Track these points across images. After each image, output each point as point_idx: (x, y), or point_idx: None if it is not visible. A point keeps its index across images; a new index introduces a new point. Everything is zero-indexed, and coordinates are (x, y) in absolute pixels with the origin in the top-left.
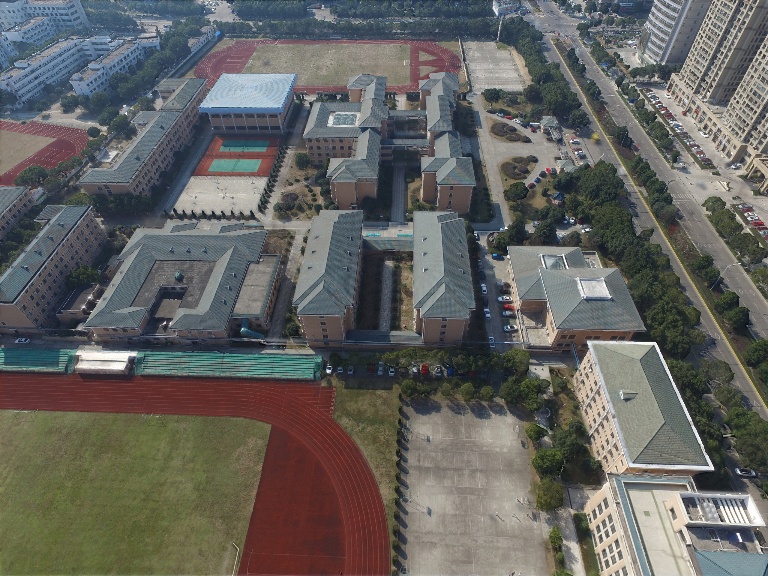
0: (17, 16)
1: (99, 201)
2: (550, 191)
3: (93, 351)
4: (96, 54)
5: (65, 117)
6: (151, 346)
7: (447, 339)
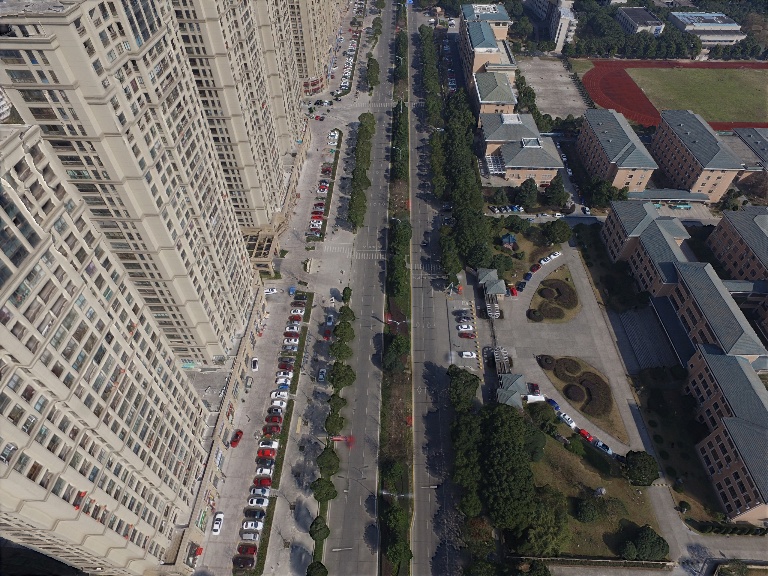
0: None
1: None
2: (513, 261)
3: None
4: None
5: None
6: None
7: None
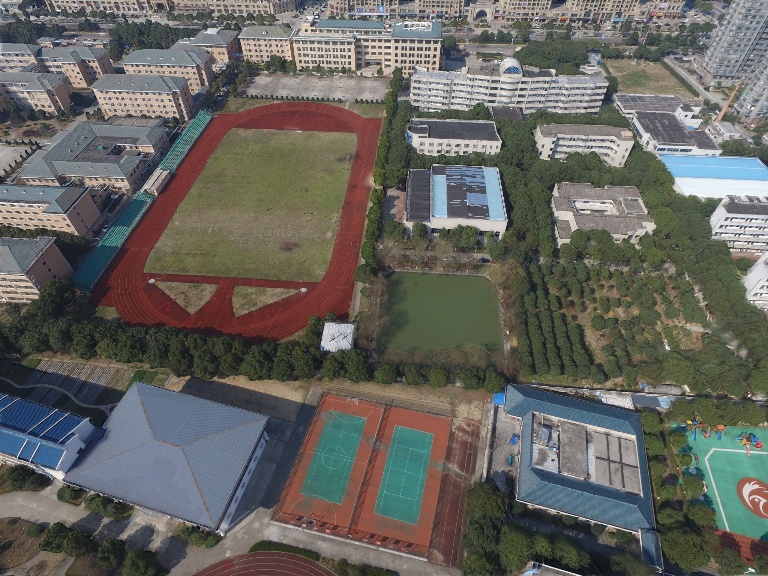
0: None
1: None
2: None
3: (145, 185)
4: None
5: None
6: (152, 171)
7: None
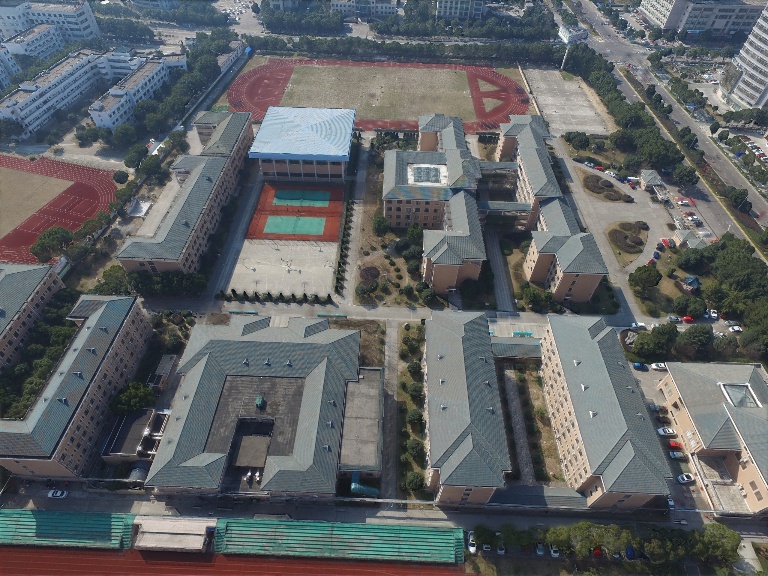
0: (18, 23)
1: (141, 281)
2: (675, 271)
3: (157, 517)
4: (112, 72)
5: (82, 152)
6: (230, 503)
7: (622, 505)
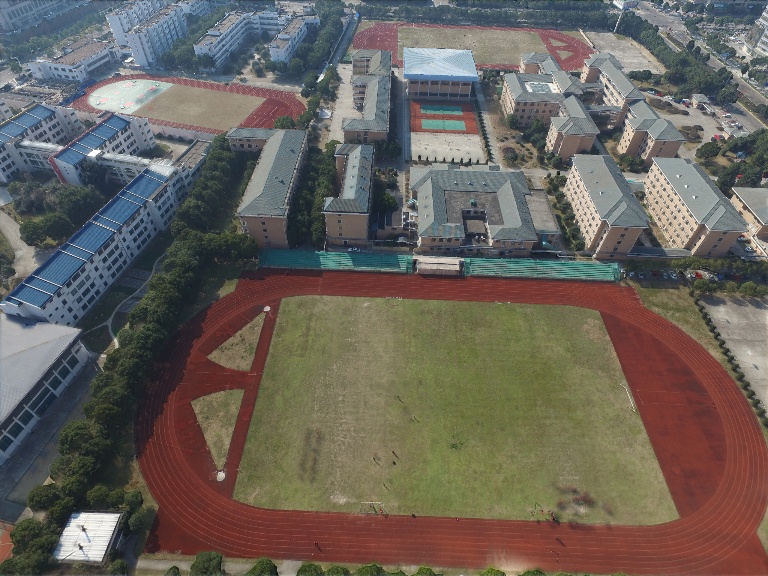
0: None
1: None
2: (727, 153)
3: (426, 257)
4: (260, 28)
5: (261, 81)
6: (464, 256)
7: (714, 252)
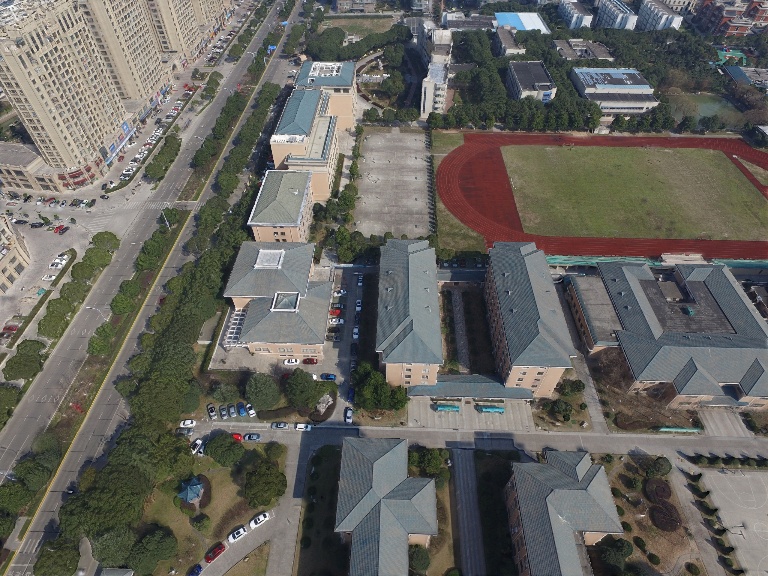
0: None
1: None
2: (188, 534)
3: None
4: None
5: None
6: None
7: None
